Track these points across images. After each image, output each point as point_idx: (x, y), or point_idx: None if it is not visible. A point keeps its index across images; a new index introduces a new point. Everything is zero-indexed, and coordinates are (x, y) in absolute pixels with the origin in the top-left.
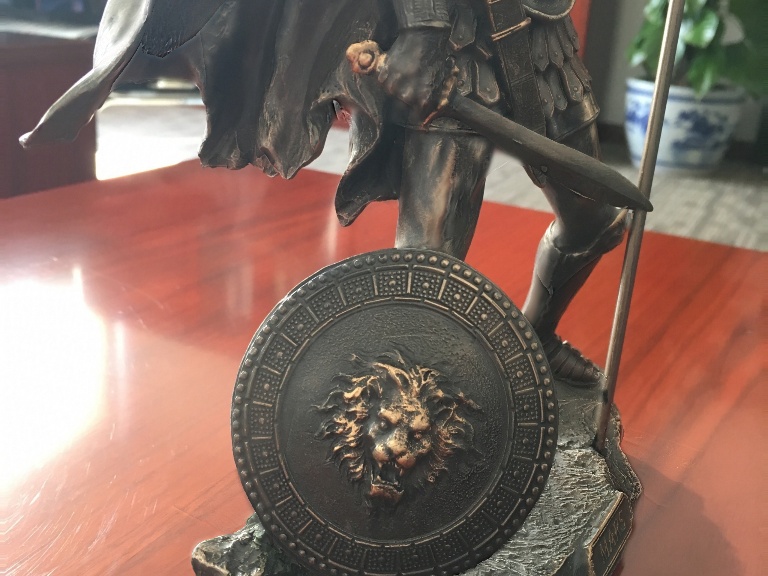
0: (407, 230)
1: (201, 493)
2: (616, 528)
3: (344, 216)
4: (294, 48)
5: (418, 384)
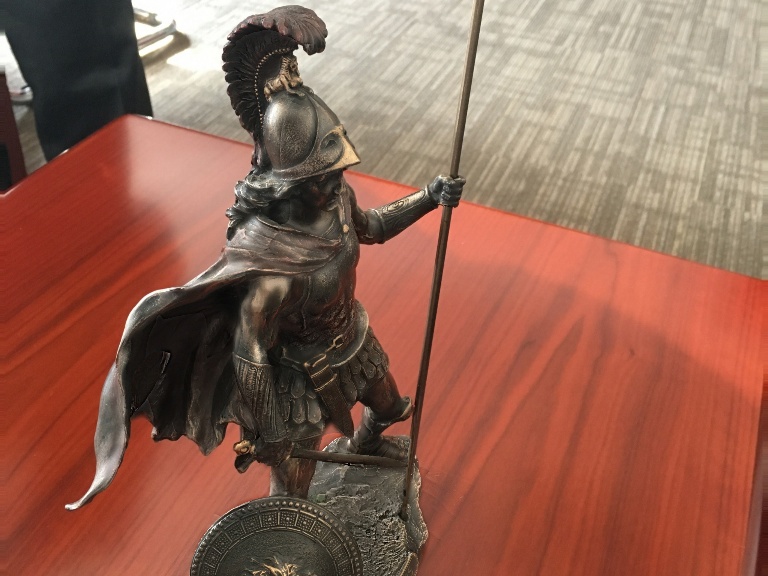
0: (276, 481)
1: (171, 565)
2: None
3: (240, 469)
4: (202, 385)
5: (286, 575)
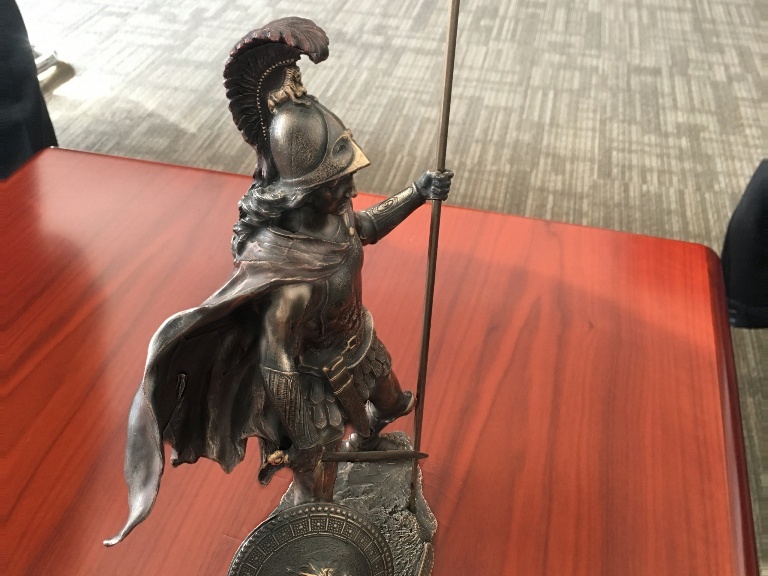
0: (301, 488)
1: None
2: (426, 569)
3: (264, 482)
4: (219, 404)
5: None
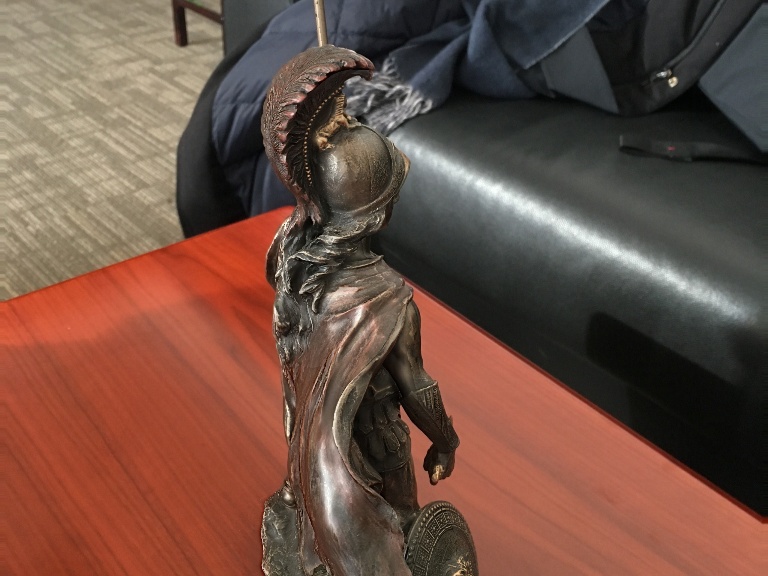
0: (401, 513)
1: None
2: None
3: None
4: None
5: (465, 569)
